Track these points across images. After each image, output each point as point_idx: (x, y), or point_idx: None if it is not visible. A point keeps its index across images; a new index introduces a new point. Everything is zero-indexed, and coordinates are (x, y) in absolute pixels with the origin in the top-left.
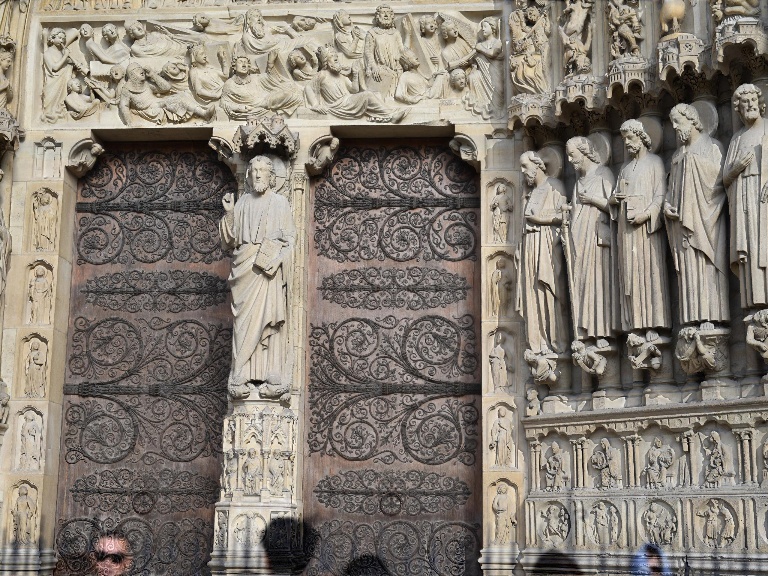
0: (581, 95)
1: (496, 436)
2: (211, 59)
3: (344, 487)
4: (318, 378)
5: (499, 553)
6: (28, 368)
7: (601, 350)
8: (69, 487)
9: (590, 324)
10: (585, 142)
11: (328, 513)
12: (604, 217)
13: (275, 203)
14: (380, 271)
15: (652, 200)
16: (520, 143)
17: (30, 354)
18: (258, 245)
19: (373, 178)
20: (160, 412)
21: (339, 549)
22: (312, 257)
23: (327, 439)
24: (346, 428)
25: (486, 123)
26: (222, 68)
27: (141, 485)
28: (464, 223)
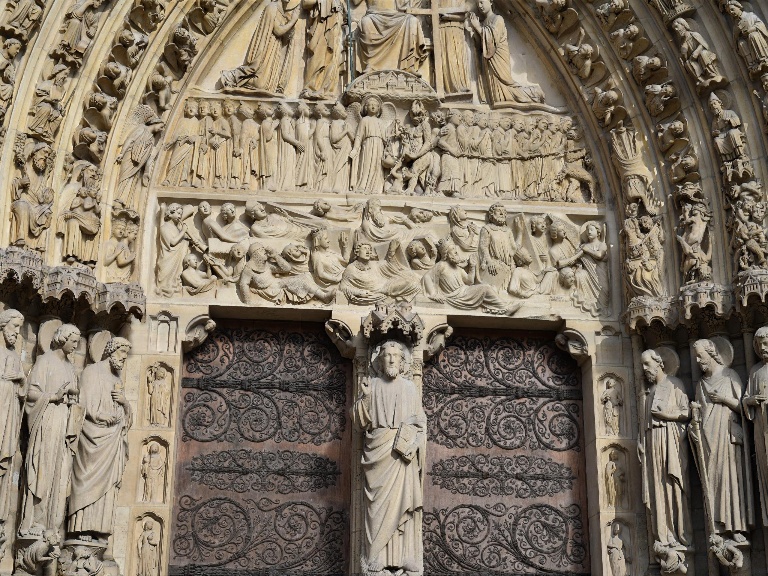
0: (712, 301)
1: None
2: (332, 244)
3: None
4: (431, 564)
5: None
6: (141, 548)
7: (740, 544)
8: None
9: (728, 519)
10: (712, 345)
11: None
12: (735, 416)
13: (406, 388)
14: (488, 458)
15: None
16: (627, 341)
17: (144, 534)
18: (396, 430)
19: (479, 367)
20: None
21: None
22: None
23: None
24: None
25: (595, 320)
26: (342, 253)
27: None
28: (567, 414)
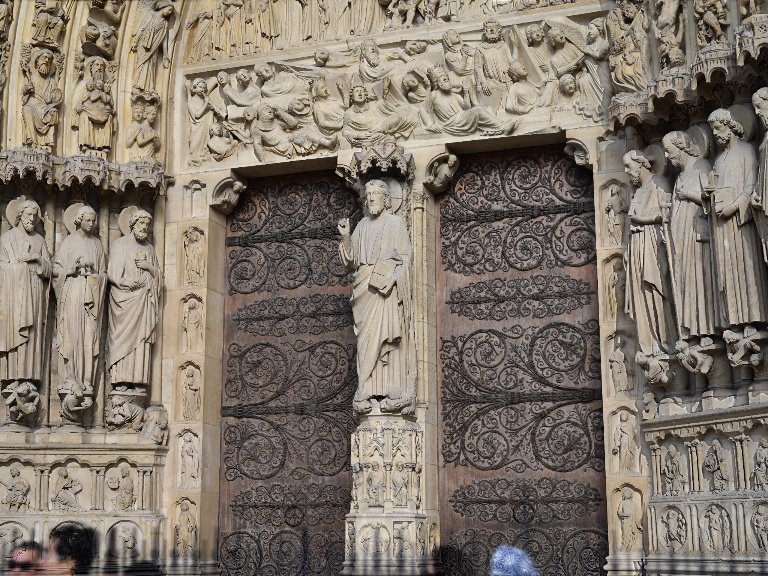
0: (671, 89)
1: (619, 441)
2: (332, 92)
3: (478, 496)
4: (449, 390)
5: (625, 560)
6: (185, 394)
7: (704, 349)
8: (229, 502)
9: (692, 323)
10: (681, 136)
11: (464, 522)
12: (703, 212)
13: (390, 224)
14: (505, 282)
15: (742, 190)
16: (632, 142)
17: (186, 381)
18: (373, 266)
19: (495, 190)
20: (306, 429)
21: (475, 557)
22: (440, 273)
23: (460, 450)
24: (478, 438)
25: (597, 126)
26: (343, 99)
27: (291, 499)
28: (586, 228)
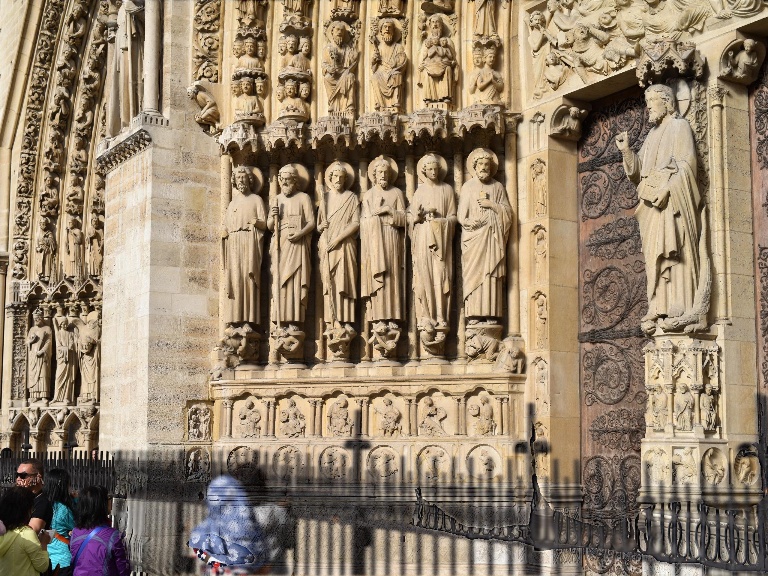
0: None
1: None
2: None
3: None
4: (767, 303)
5: None
6: None
7: None
8: (589, 427)
9: None
10: None
11: None
12: None
13: (670, 130)
14: None
15: None
16: None
17: (538, 310)
18: None
19: None
20: None
21: None
22: (756, 172)
23: None
24: None
25: None
26: None
27: (636, 424)
28: None
